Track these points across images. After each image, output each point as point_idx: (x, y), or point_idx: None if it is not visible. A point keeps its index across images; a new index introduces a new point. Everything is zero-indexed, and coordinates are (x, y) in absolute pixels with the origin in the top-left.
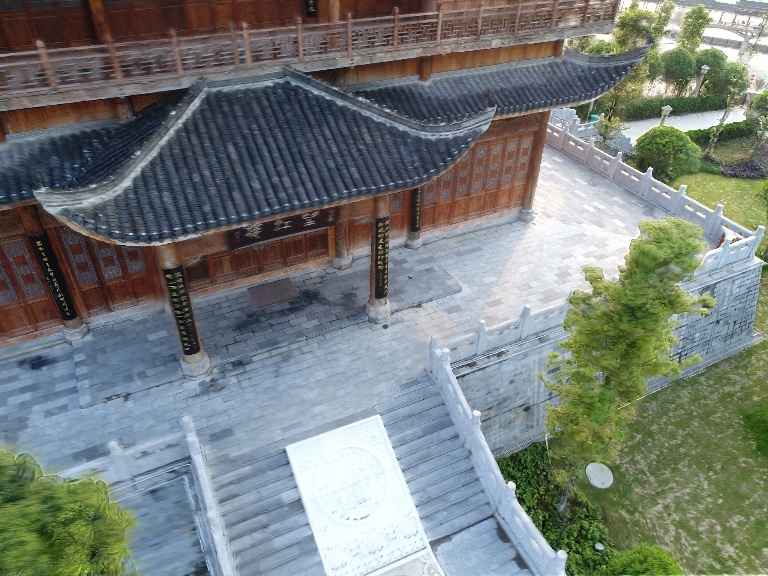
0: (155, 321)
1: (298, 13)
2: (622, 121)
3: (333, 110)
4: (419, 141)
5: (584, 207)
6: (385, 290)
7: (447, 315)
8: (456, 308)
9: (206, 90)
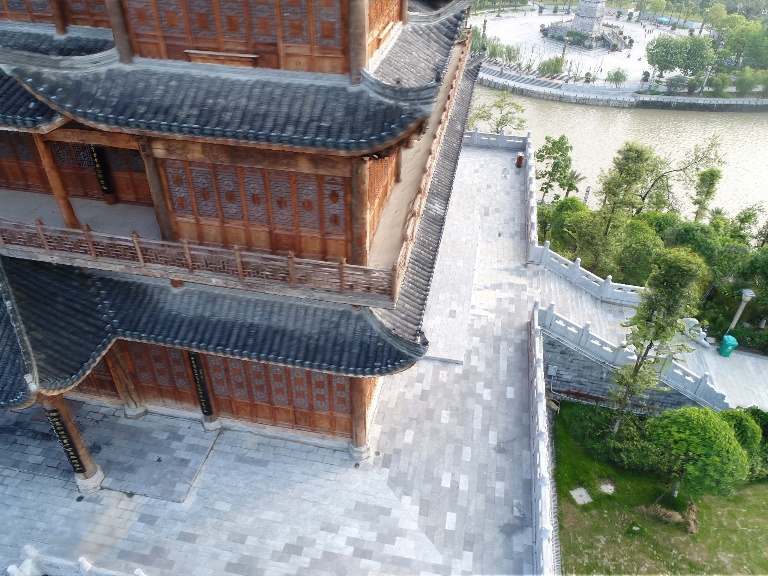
0: None
1: (98, 187)
2: None
3: None
4: None
5: (442, 475)
6: (77, 468)
7: (135, 521)
8: (151, 519)
9: None
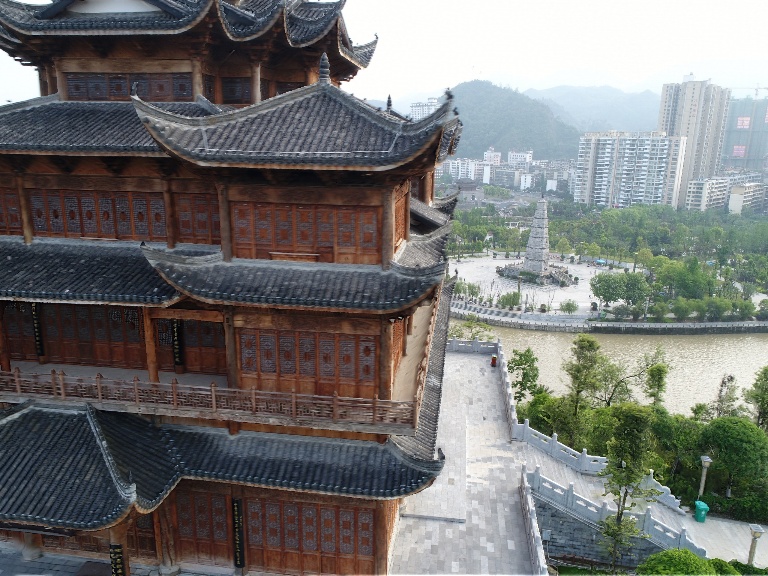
0: (9, 559)
1: (171, 360)
2: (756, 522)
3: (89, 445)
4: (113, 491)
5: None
6: None
7: None
8: None
9: (31, 408)
